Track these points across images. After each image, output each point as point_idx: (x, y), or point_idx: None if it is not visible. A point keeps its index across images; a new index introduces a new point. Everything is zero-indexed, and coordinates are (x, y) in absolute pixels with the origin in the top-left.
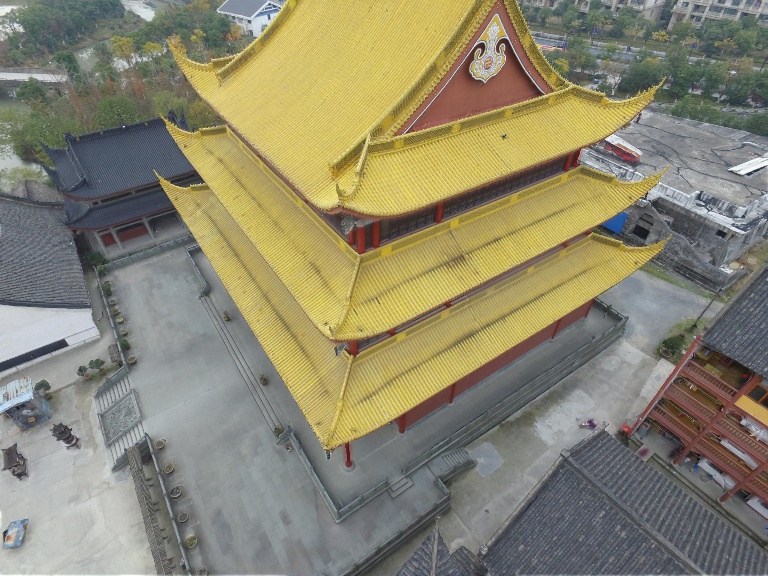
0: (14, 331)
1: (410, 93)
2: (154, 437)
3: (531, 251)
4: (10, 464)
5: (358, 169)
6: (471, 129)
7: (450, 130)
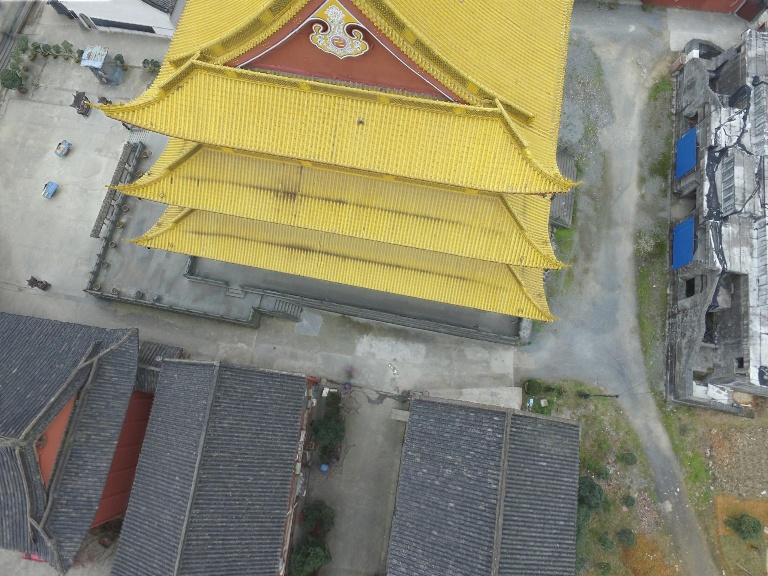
0: (115, 3)
1: (238, 33)
2: (148, 146)
3: (363, 232)
4: (75, 104)
5: (161, 84)
6: (328, 94)
7: (298, 85)
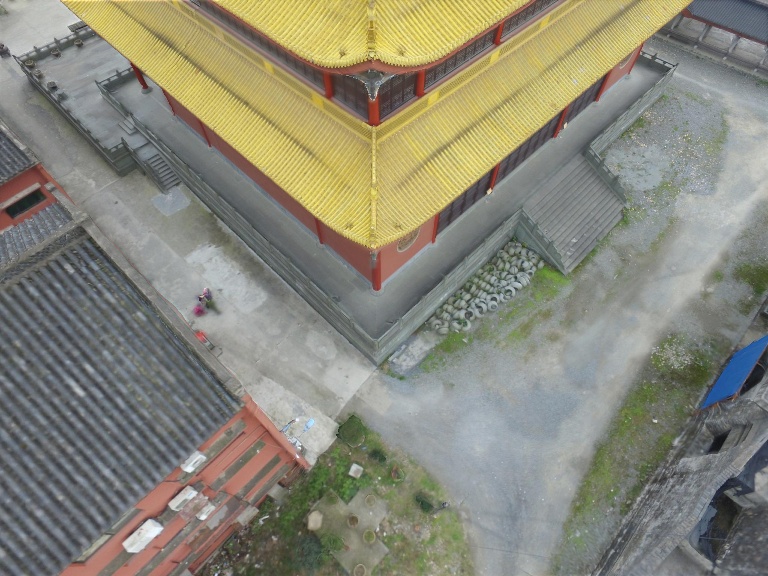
0: None
1: None
2: None
3: None
4: None
5: None
6: None
7: None
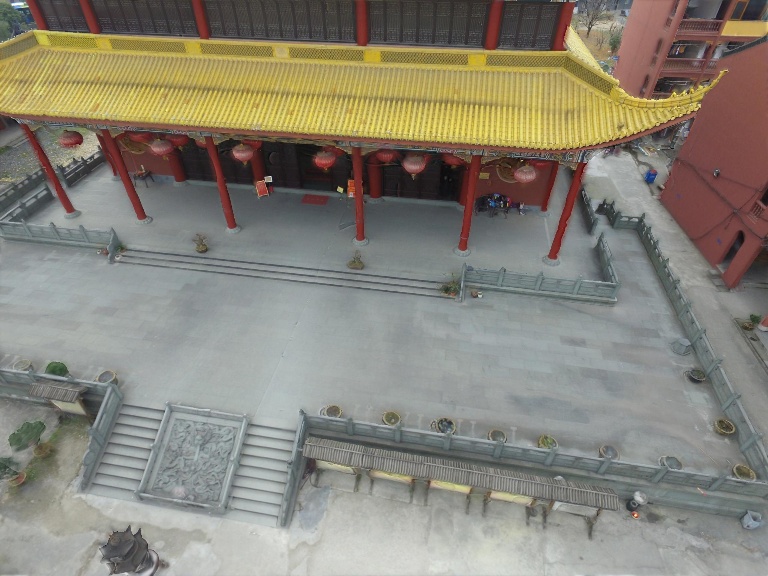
0: None
1: None
2: None
3: None
4: None
5: None
6: None
7: None
